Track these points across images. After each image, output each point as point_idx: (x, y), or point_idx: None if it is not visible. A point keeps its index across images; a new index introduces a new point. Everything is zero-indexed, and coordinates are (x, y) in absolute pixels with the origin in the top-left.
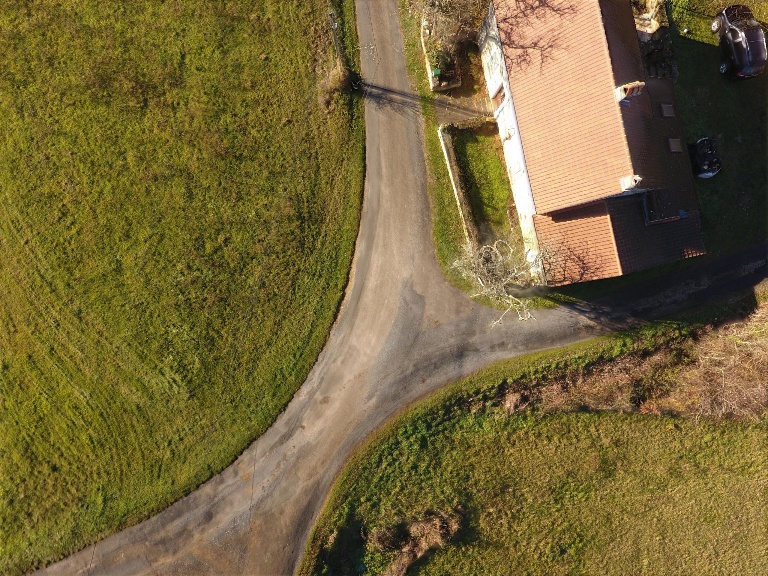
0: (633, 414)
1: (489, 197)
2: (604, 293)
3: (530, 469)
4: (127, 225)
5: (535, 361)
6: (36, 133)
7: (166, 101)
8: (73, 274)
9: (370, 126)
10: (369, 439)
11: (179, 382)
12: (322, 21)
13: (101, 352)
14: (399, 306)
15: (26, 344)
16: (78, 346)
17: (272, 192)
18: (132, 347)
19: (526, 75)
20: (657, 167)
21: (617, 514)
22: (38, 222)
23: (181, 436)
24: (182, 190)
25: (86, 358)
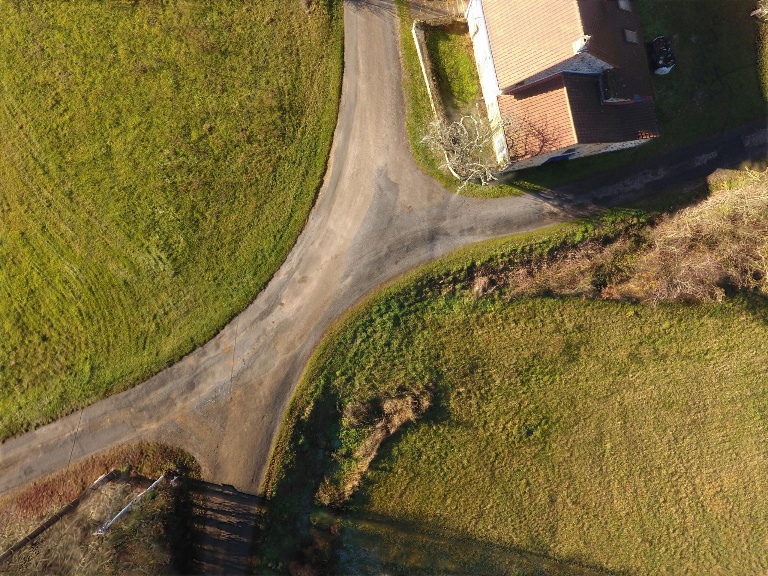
0: (595, 299)
1: (459, 91)
2: (567, 181)
3: (498, 350)
4: (117, 113)
5: (502, 245)
6: (32, 26)
7: None
8: (65, 157)
9: (348, 26)
10: (344, 316)
11: (165, 260)
12: None
13: (91, 231)
14: (374, 192)
15: (19, 222)
16: (69, 225)
17: (255, 85)
18: (120, 226)
19: None
20: (610, 44)
21: (581, 398)
22: (32, 109)
23: (166, 310)
24: (170, 81)
25: (76, 236)
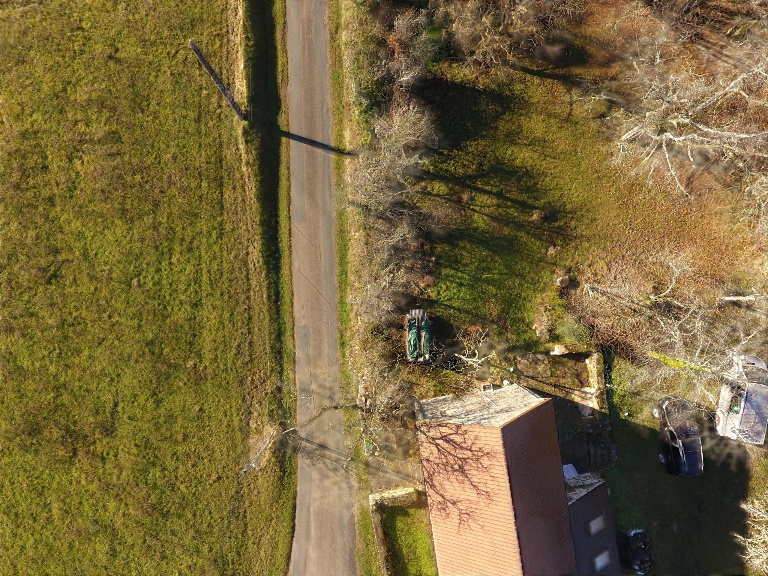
0: None
1: (417, 573)
2: None
3: None
4: None
5: None
6: None
7: (96, 451)
8: None
9: (302, 483)
10: None
11: None
12: (260, 370)
13: None
14: None
15: None
16: None
17: (197, 553)
18: None
19: (445, 524)
20: None
21: None
22: None
23: None
24: (106, 548)
25: None
